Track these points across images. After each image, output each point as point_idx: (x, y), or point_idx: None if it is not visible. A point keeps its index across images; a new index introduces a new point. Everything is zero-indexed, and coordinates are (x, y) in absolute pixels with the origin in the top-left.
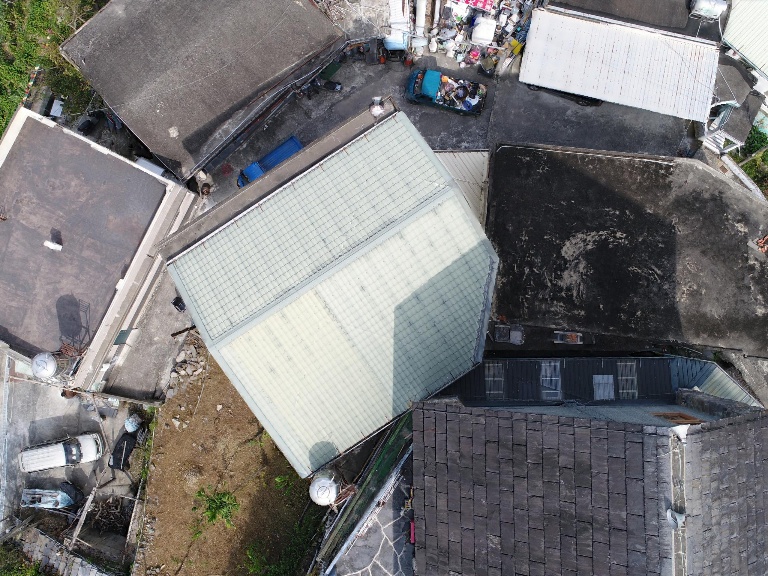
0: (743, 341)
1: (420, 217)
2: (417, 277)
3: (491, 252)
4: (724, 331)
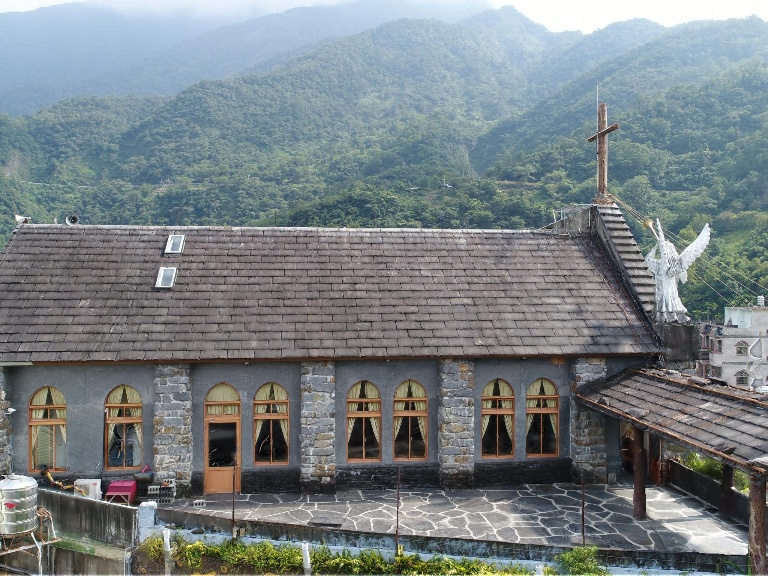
0: None
1: None
2: None
3: None
4: None
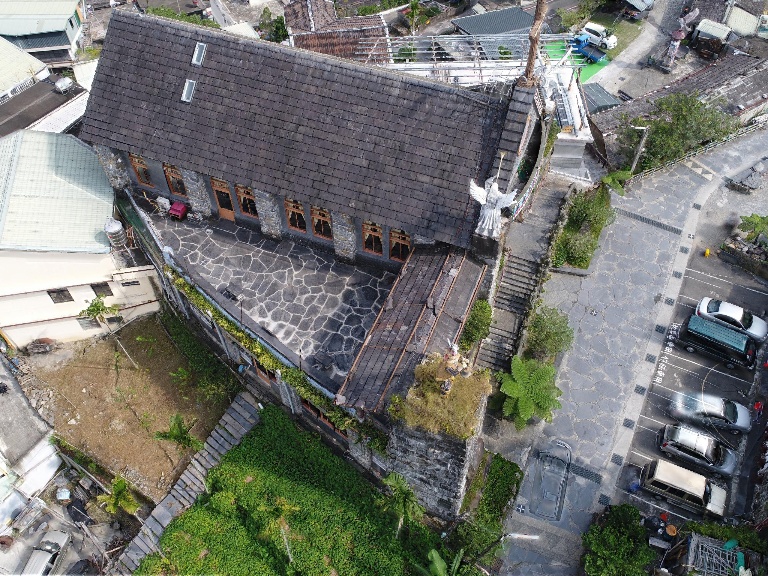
0: None
1: (21, 147)
2: (49, 162)
3: (65, 135)
4: None
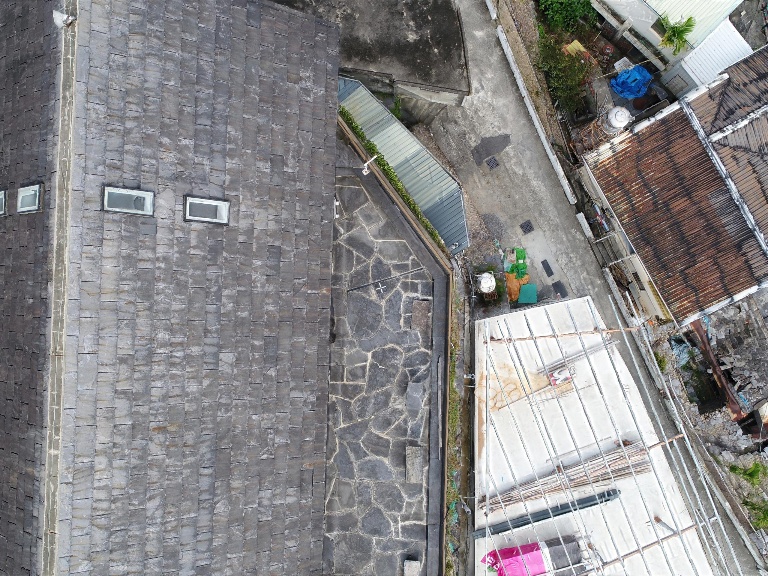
0: (394, 66)
1: None
2: None
3: None
4: (375, 55)
